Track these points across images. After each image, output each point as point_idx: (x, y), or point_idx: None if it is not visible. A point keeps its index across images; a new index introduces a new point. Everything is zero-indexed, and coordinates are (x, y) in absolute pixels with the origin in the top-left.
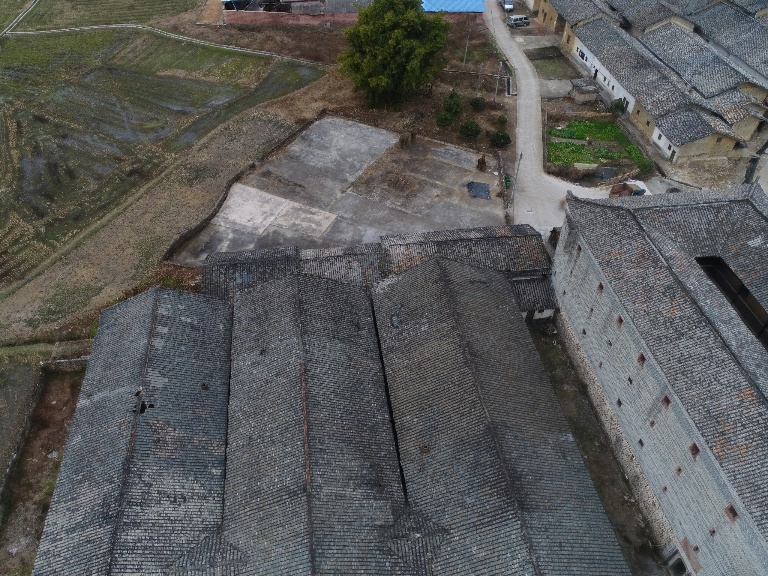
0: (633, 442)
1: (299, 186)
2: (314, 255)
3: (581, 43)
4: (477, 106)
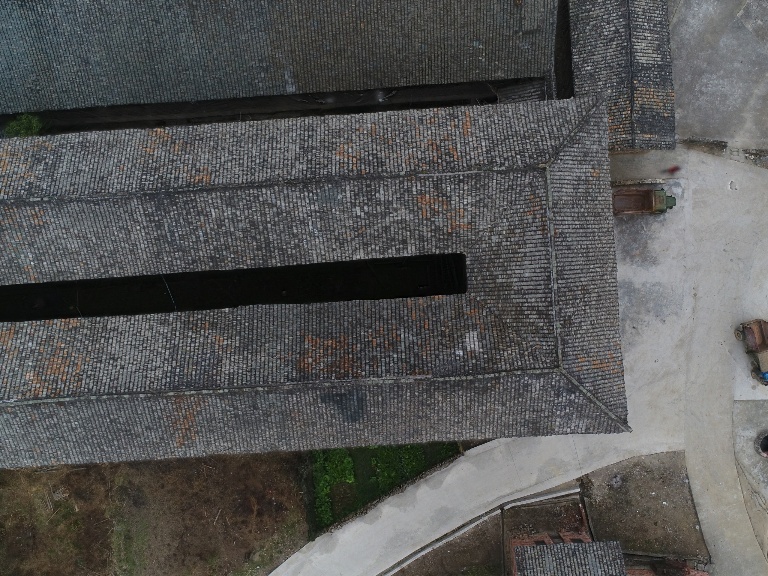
0: None
1: None
2: None
3: None
4: None
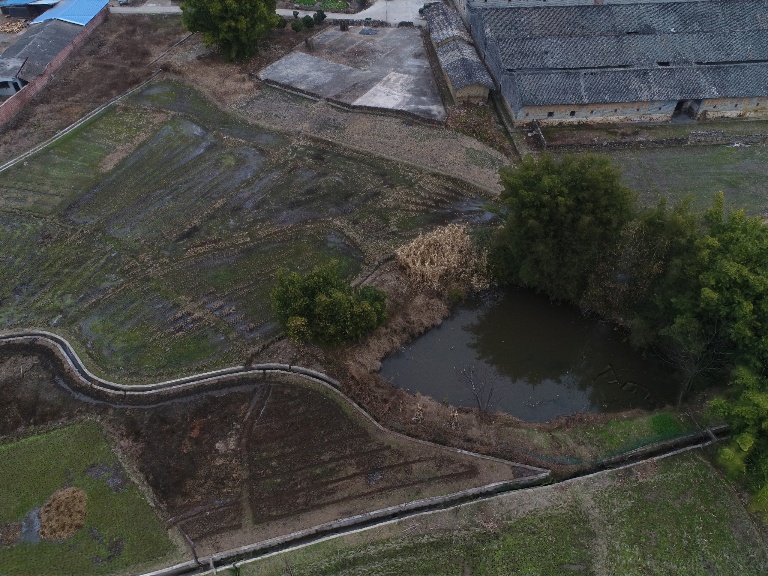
0: (559, 3)
1: (356, 84)
2: (456, 58)
3: None
4: None
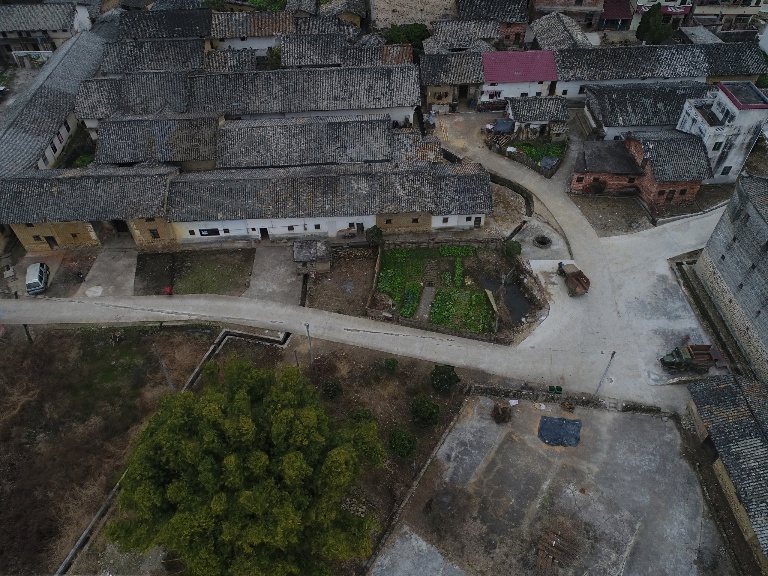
0: None
1: None
2: None
3: (199, 223)
4: (340, 390)
